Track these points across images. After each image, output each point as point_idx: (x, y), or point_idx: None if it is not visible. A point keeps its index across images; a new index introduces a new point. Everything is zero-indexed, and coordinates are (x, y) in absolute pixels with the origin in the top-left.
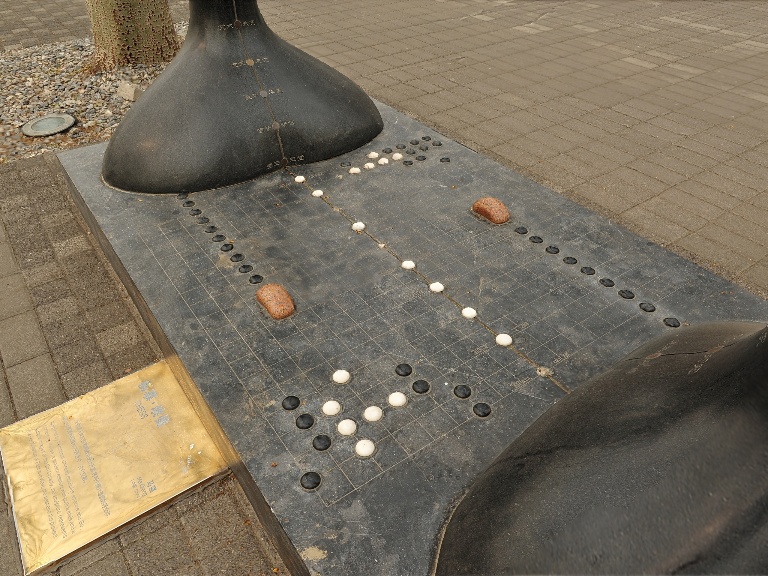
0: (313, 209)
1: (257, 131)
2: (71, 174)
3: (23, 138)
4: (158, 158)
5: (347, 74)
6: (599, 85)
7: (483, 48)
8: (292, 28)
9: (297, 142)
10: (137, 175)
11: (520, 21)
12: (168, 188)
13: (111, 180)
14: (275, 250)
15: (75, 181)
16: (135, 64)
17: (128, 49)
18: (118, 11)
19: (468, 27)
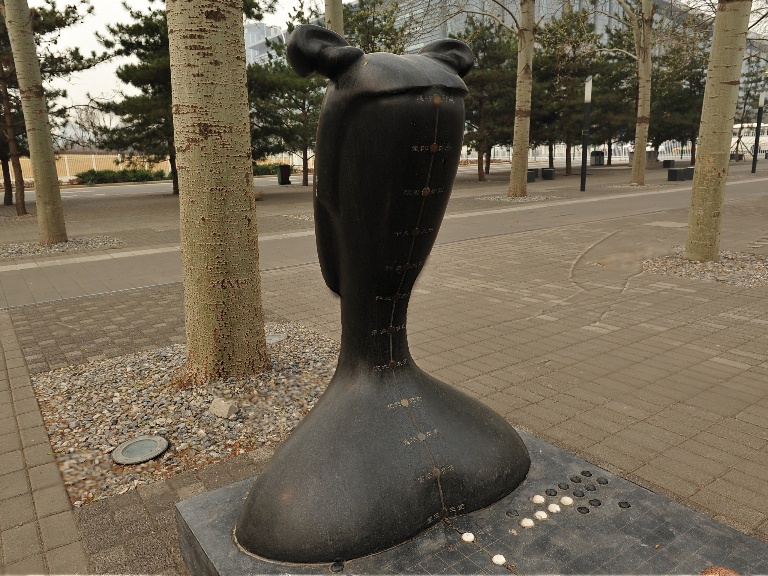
0: None
1: (418, 480)
2: (197, 534)
3: (113, 466)
4: (311, 519)
5: None
6: (705, 390)
7: (563, 350)
8: None
9: (458, 489)
10: (284, 540)
11: (585, 321)
12: (320, 556)
13: (250, 545)
14: None
15: (204, 545)
16: (226, 377)
17: (222, 364)
18: (219, 330)
19: (537, 328)
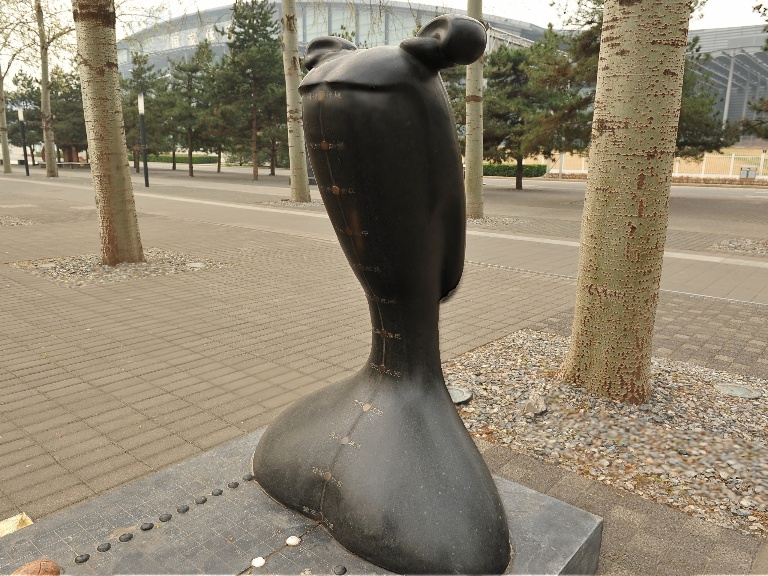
0: (221, 566)
1: (313, 468)
2: None
3: None
4: None
5: None
6: None
7: None
8: None
9: (334, 507)
10: None
11: None
12: None
13: None
14: (135, 558)
15: None
16: (580, 386)
17: (579, 370)
18: (581, 335)
19: None
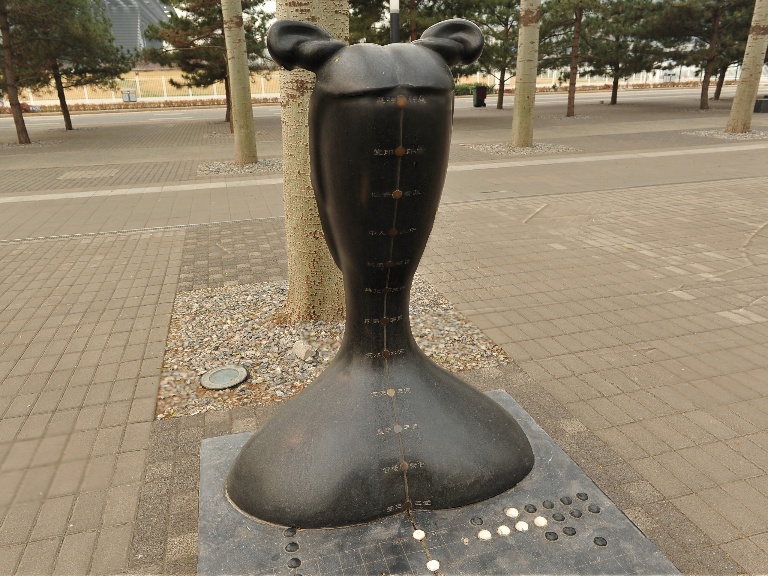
0: None
1: (382, 470)
2: (202, 472)
3: (199, 388)
4: (276, 485)
5: (517, 355)
6: None
7: (678, 338)
8: (474, 288)
9: (425, 486)
10: (253, 498)
11: (727, 305)
12: (279, 519)
13: (231, 493)
14: None
15: (202, 483)
16: (316, 320)
17: (313, 307)
18: (311, 277)
19: (663, 306)
